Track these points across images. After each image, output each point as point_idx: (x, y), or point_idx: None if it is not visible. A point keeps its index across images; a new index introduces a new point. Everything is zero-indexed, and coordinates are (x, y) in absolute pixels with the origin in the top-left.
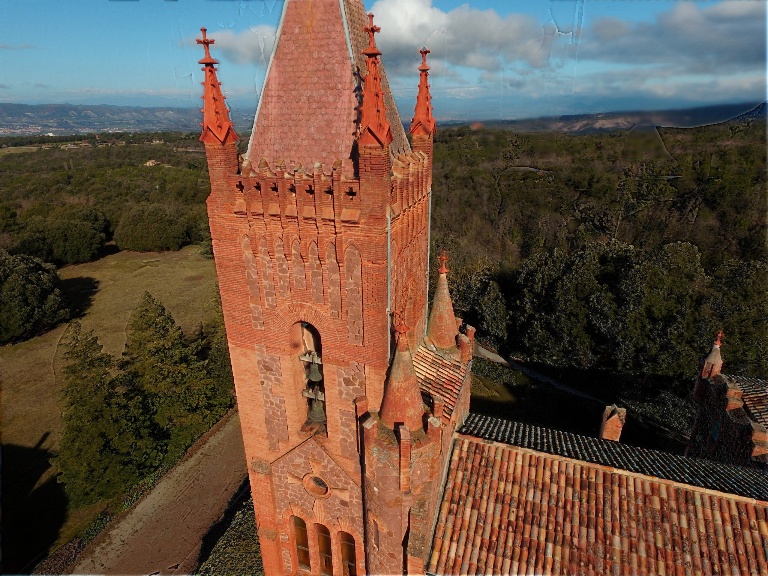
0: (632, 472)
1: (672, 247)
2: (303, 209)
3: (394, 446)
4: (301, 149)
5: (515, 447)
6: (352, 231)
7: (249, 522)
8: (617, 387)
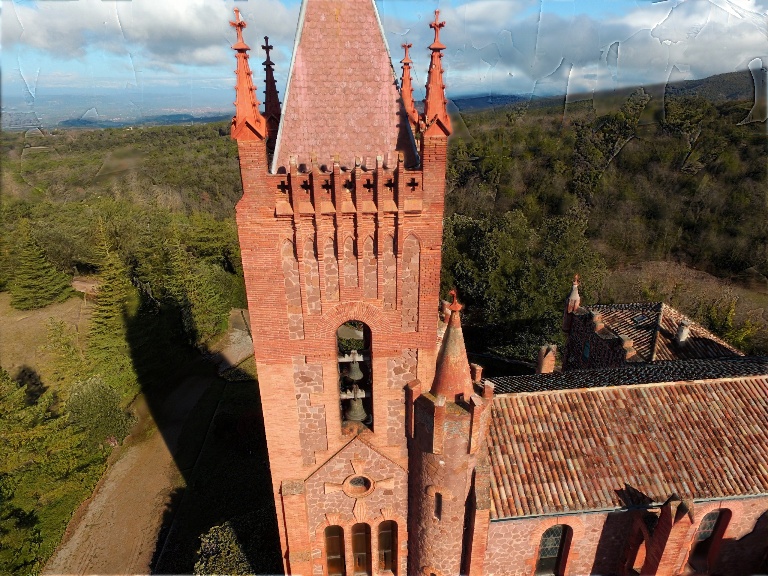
0: (599, 387)
1: (511, 214)
2: (362, 204)
3: (466, 415)
4: (341, 143)
5: (514, 394)
6: (412, 221)
7: (217, 568)
8: (484, 338)
